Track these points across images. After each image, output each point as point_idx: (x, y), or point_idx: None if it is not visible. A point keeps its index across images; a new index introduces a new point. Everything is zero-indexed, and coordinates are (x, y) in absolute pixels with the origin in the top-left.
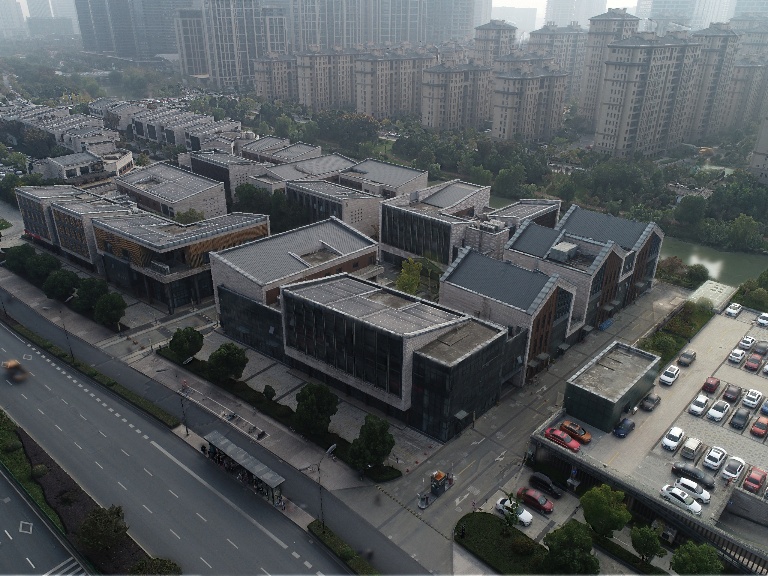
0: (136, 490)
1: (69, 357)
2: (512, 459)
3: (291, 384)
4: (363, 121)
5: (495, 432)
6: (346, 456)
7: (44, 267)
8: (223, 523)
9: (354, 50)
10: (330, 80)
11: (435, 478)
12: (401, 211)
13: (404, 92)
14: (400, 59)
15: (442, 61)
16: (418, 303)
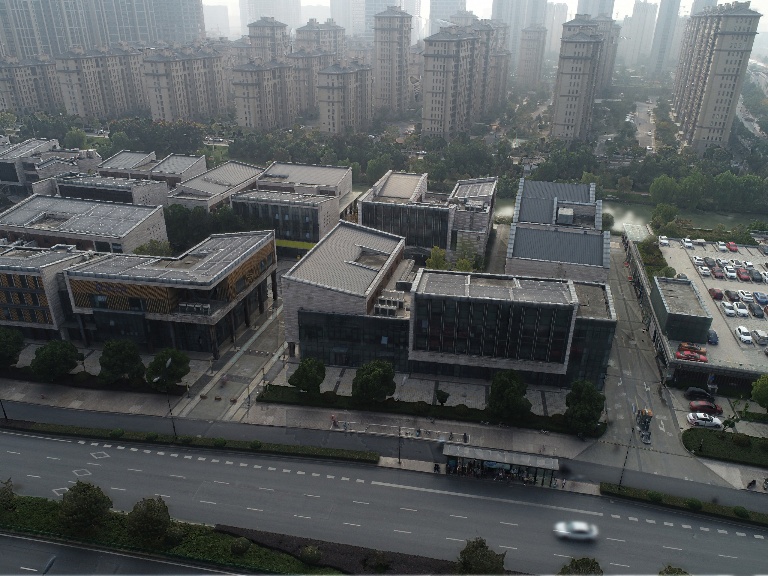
0: (421, 529)
1: (163, 436)
2: (655, 386)
3: (428, 387)
4: (186, 127)
5: (621, 371)
6: (556, 427)
7: (12, 346)
8: (533, 520)
9: (120, 51)
10: (101, 85)
11: (648, 415)
12: (387, 205)
13: (200, 94)
14: (192, 59)
15: (250, 59)
16: (516, 280)
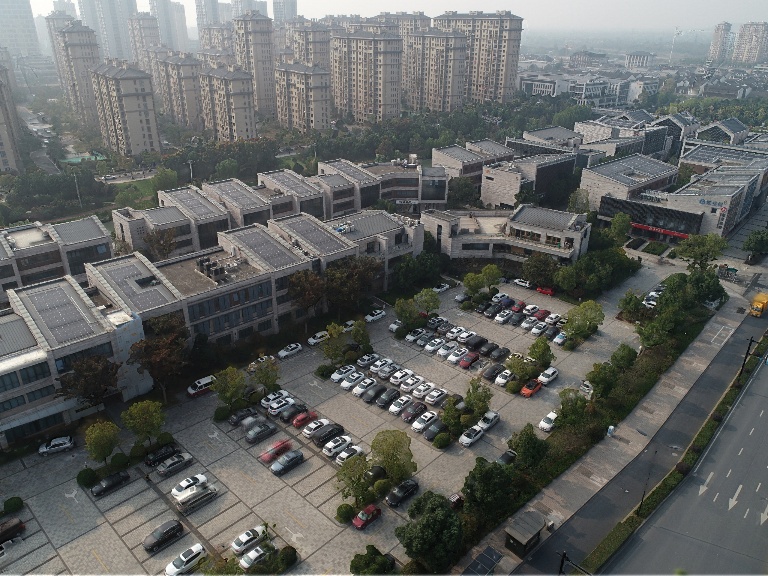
0: None
1: None
2: None
3: None
4: (272, 142)
5: None
6: None
7: None
8: None
9: None
10: None
11: None
12: None
13: None
14: None
15: (235, 67)
16: None
